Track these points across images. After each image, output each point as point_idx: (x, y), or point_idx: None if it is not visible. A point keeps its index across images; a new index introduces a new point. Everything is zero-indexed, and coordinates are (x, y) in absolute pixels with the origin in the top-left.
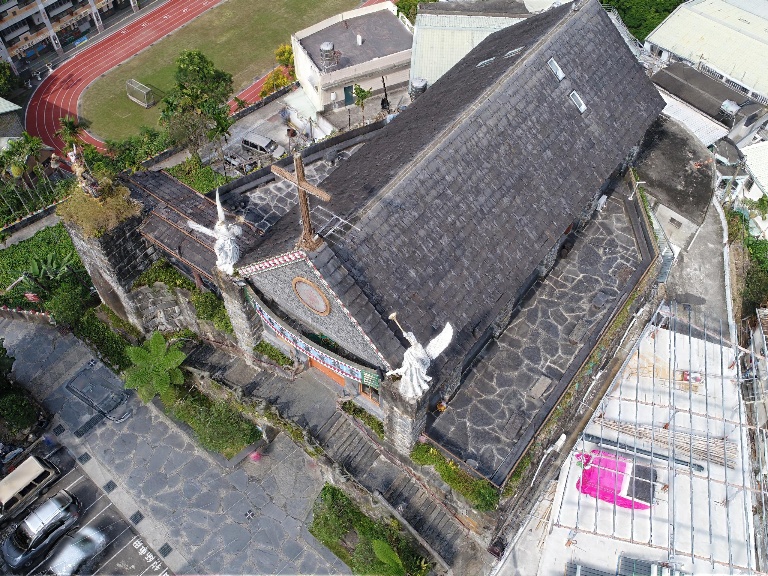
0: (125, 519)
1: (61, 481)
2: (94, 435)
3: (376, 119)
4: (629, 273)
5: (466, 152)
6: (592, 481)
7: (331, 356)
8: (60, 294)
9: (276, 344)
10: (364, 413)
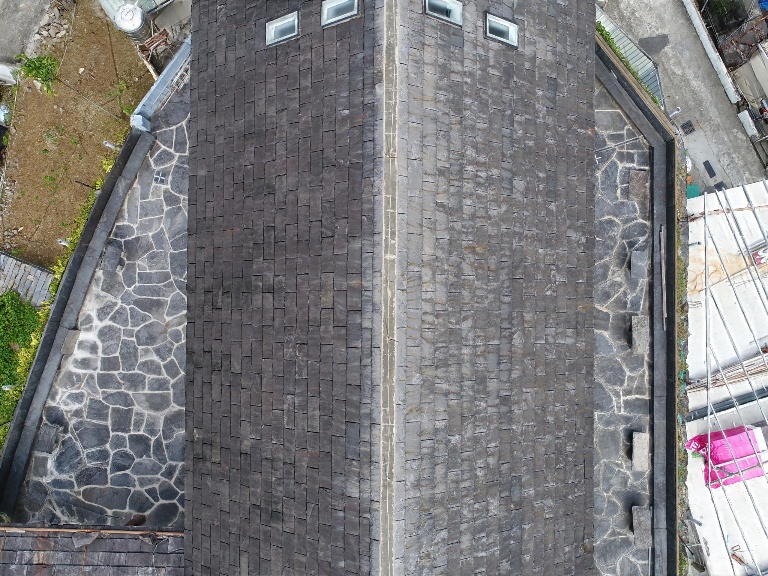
0: None
1: None
2: None
3: (57, 8)
4: (644, 181)
5: (432, 350)
6: None
7: None
8: None
9: None
10: None
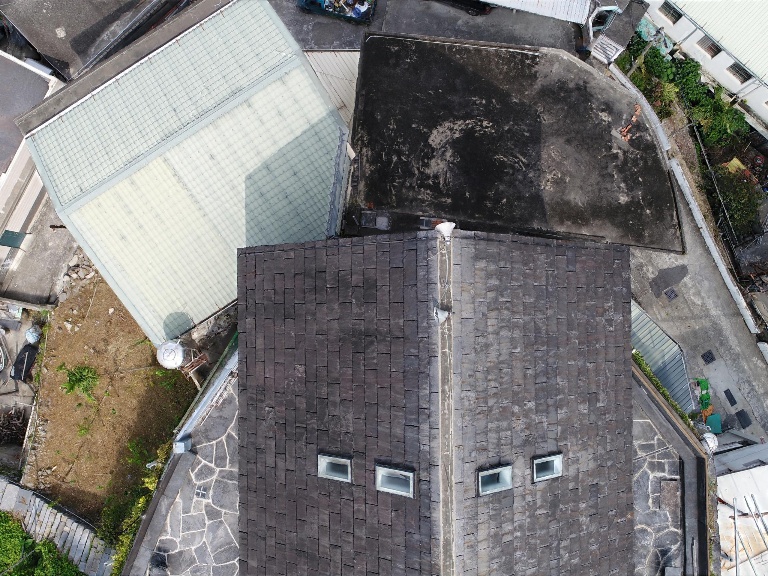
0: None
1: None
2: None
3: None
4: (675, 491)
5: None
6: None
7: None
8: None
9: None
10: None
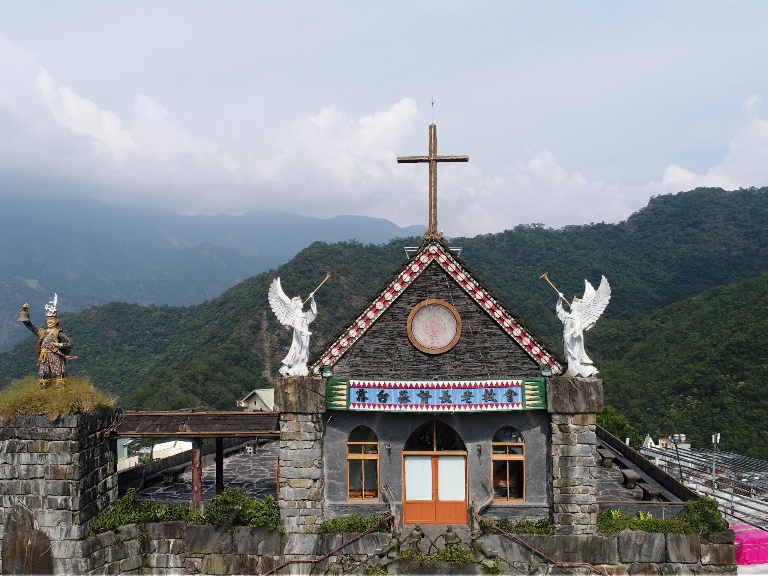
0: None
1: None
2: None
3: None
4: None
5: None
6: (746, 540)
7: (483, 379)
8: None
9: (350, 508)
10: (510, 521)
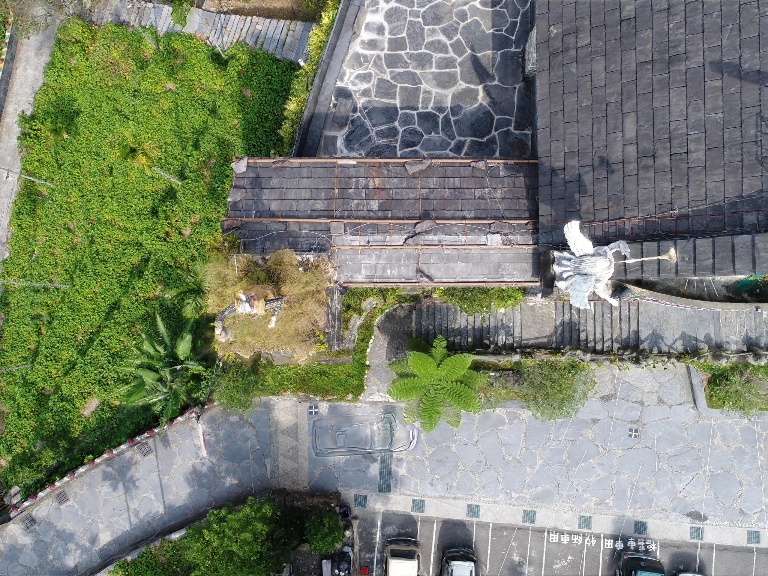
0: (519, 527)
1: (420, 543)
2: (402, 478)
3: None
4: None
5: None
6: None
7: None
8: (221, 383)
9: None
10: None
